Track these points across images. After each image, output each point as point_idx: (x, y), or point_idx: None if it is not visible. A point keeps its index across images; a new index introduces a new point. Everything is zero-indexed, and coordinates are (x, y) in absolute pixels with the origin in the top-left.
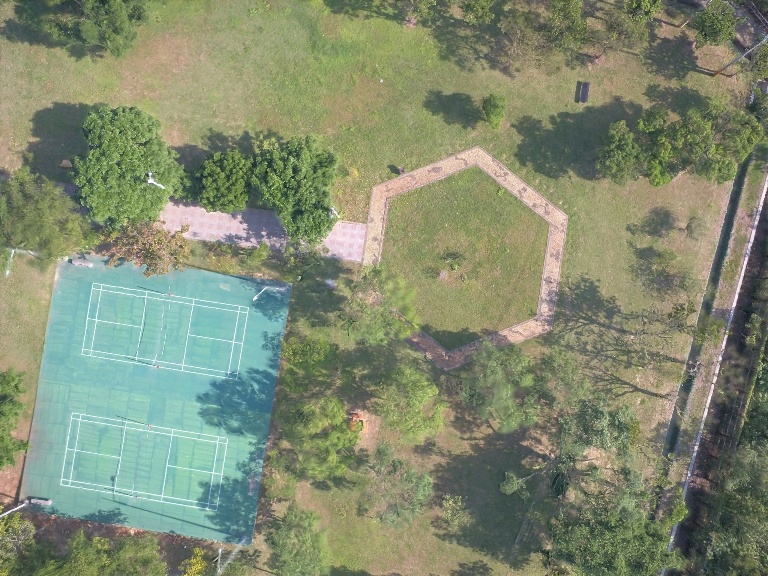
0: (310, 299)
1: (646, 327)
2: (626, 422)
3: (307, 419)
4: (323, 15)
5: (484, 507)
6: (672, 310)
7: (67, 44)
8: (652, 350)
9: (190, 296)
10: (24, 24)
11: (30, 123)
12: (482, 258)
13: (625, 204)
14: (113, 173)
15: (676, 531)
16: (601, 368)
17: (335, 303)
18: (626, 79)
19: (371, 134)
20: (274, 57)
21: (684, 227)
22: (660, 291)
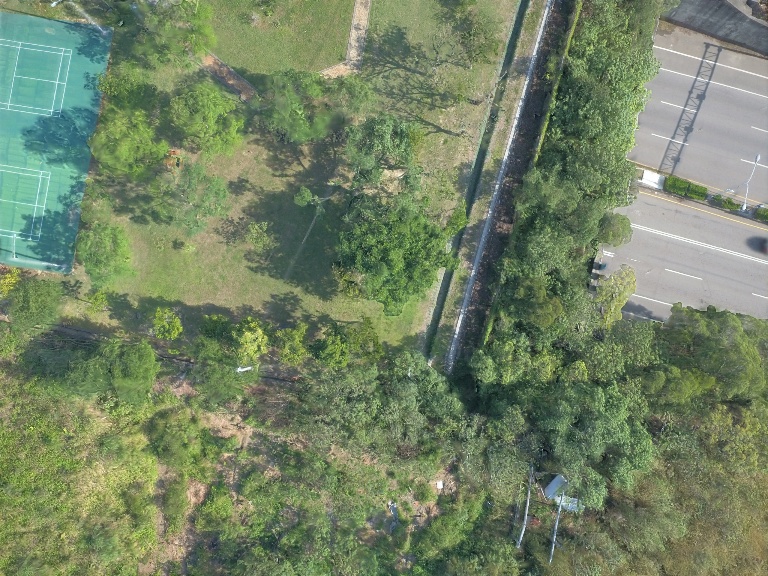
0: (131, 43)
1: (449, 71)
2: None
3: (108, 128)
4: None
5: (294, 241)
6: None
7: None
8: (455, 93)
9: (17, 40)
10: None
11: None
12: (295, 6)
13: None
14: None
15: (483, 273)
16: (406, 110)
17: (154, 47)
18: None
19: None
20: None
21: None
22: None
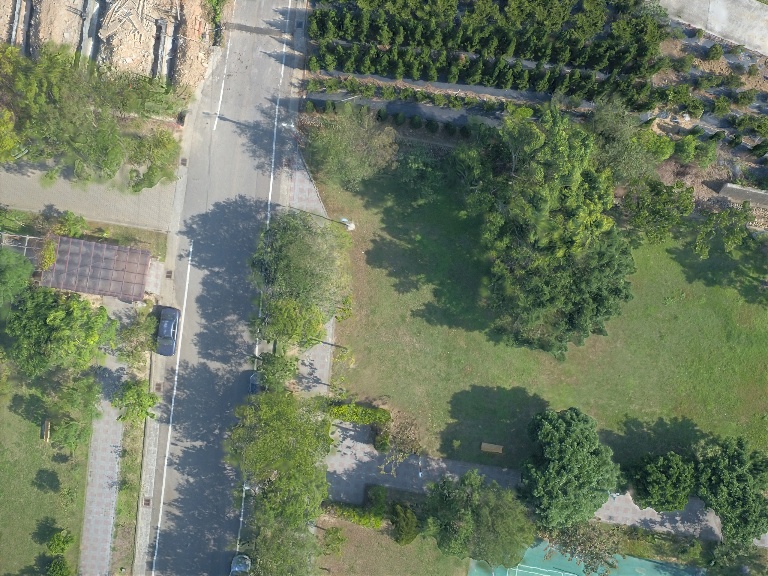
0: None
1: None
2: None
3: None
4: (738, 305)
5: None
6: None
7: (485, 328)
8: None
9: None
10: (443, 307)
11: (448, 405)
12: None
13: None
14: (571, 485)
15: None
16: None
17: None
18: None
19: None
20: (689, 345)
21: None
22: None
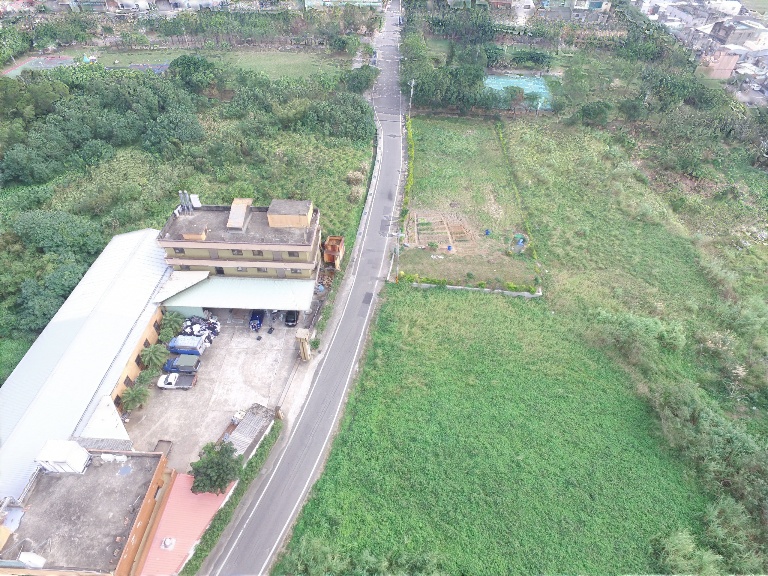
0: None
1: None
2: None
3: None
4: None
5: None
6: None
7: None
8: None
9: None
10: None
11: None
12: None
13: None
14: None
15: None
16: None
17: None
18: None
19: None
20: None
21: None
22: None
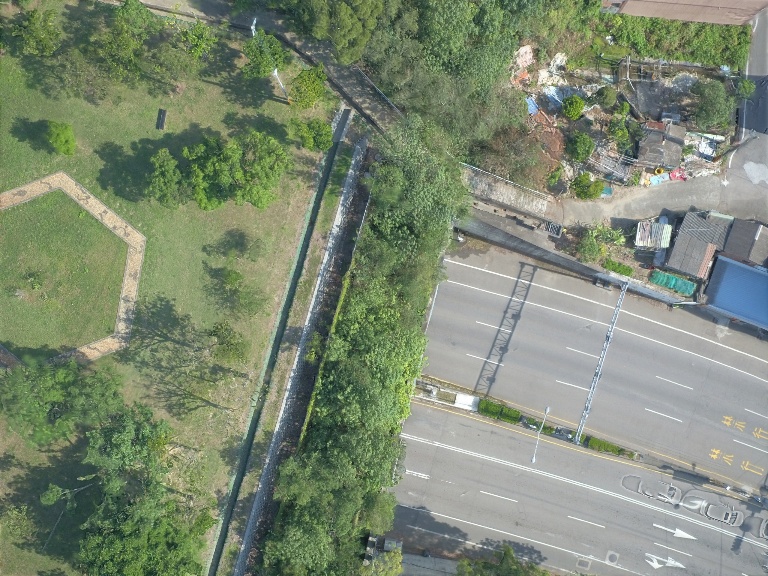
0: None
1: None
2: (152, 436)
3: None
4: None
5: (61, 517)
6: (213, 329)
7: None
8: (224, 366)
9: None
10: None
11: None
12: (62, 278)
13: (202, 226)
14: None
15: (259, 540)
16: (175, 383)
17: None
18: (206, 107)
19: None
20: None
21: None
22: (233, 310)
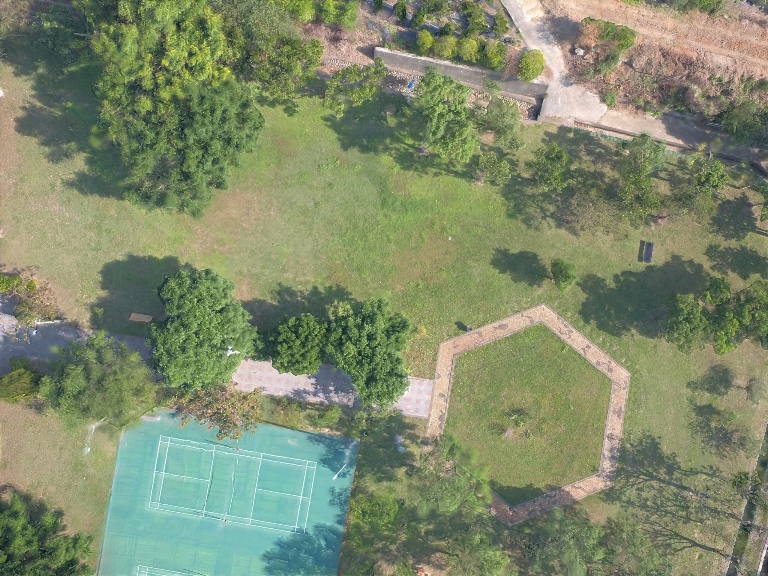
0: (377, 454)
1: (705, 483)
2: None
3: None
4: (393, 172)
5: None
6: (736, 479)
7: None
8: (710, 506)
9: (258, 450)
10: (93, 175)
11: (99, 275)
12: (546, 415)
13: (686, 362)
14: (191, 342)
15: None
16: (661, 523)
17: (402, 458)
18: (688, 239)
19: (439, 291)
20: (344, 213)
21: (742, 385)
22: (719, 448)
